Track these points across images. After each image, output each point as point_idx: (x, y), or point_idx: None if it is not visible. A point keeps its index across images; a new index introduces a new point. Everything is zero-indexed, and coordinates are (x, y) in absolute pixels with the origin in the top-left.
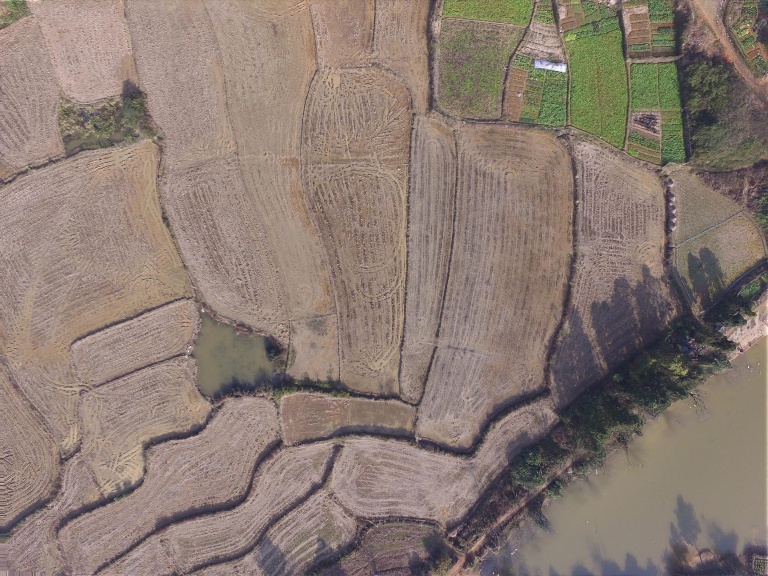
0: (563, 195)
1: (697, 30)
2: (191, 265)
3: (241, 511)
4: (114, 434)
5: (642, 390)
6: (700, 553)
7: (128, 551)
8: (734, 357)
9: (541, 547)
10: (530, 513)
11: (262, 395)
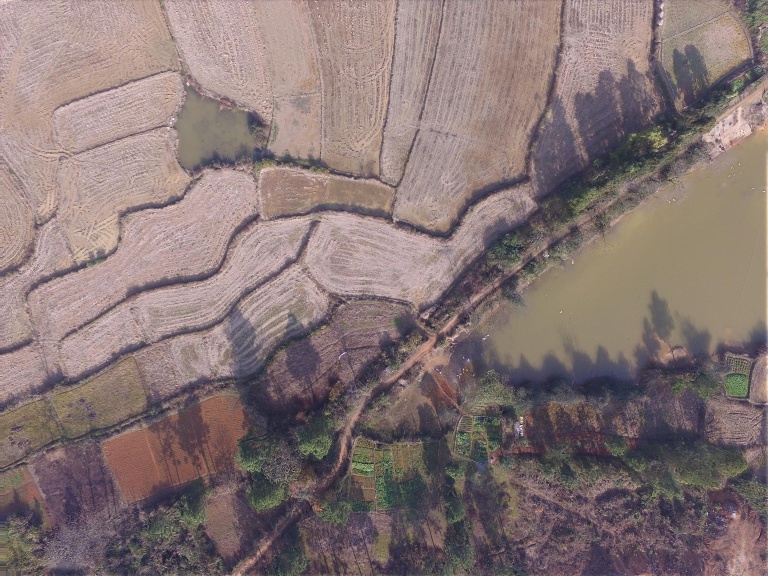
0: None
1: None
2: (179, 37)
3: (213, 283)
4: (91, 202)
5: (621, 164)
6: (673, 349)
7: (97, 318)
8: (715, 155)
9: (513, 335)
10: (503, 292)
11: (242, 169)
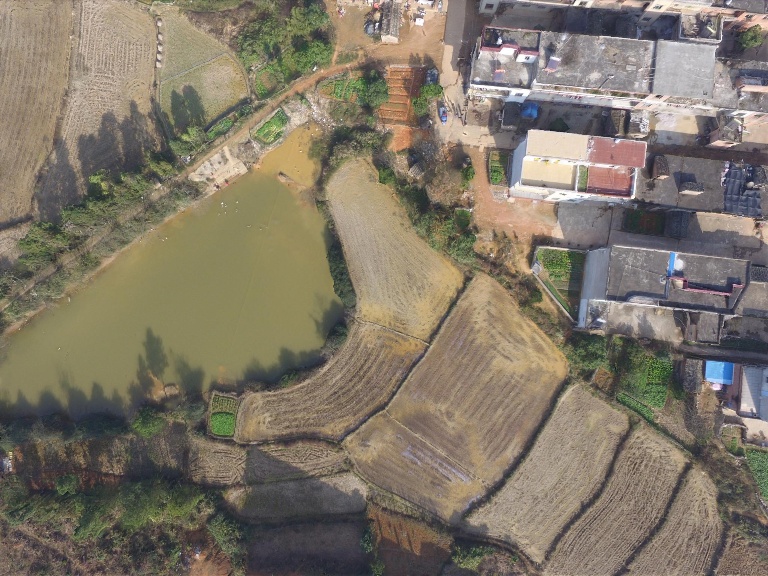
0: (64, 33)
1: None
2: None
3: None
4: None
5: None
6: (164, 387)
7: None
8: (210, 193)
9: (13, 371)
10: None
11: None
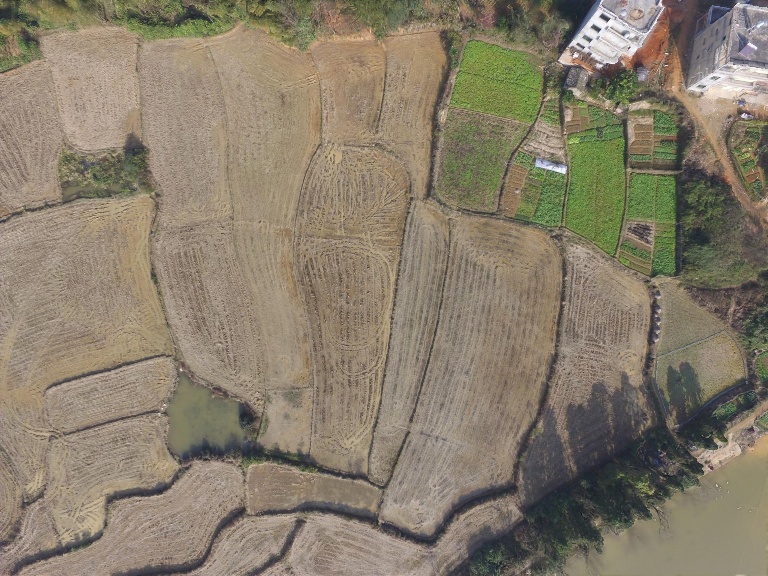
0: (551, 294)
1: (699, 148)
2: (174, 324)
3: (197, 575)
4: (79, 483)
5: (607, 503)
6: None
7: None
8: (704, 474)
9: None
10: None
11: (231, 461)
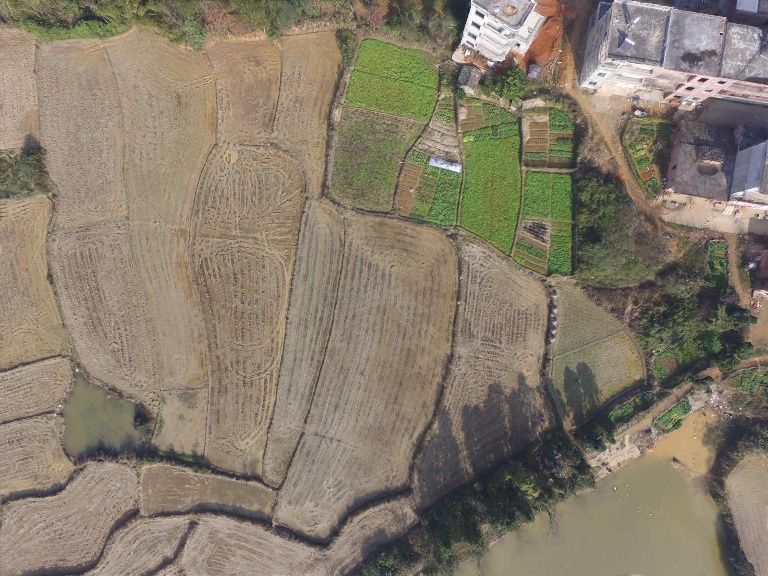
0: (447, 294)
1: (594, 145)
2: (70, 324)
3: None
4: None
5: (495, 506)
6: None
7: None
8: (602, 476)
9: None
10: None
11: (125, 462)
